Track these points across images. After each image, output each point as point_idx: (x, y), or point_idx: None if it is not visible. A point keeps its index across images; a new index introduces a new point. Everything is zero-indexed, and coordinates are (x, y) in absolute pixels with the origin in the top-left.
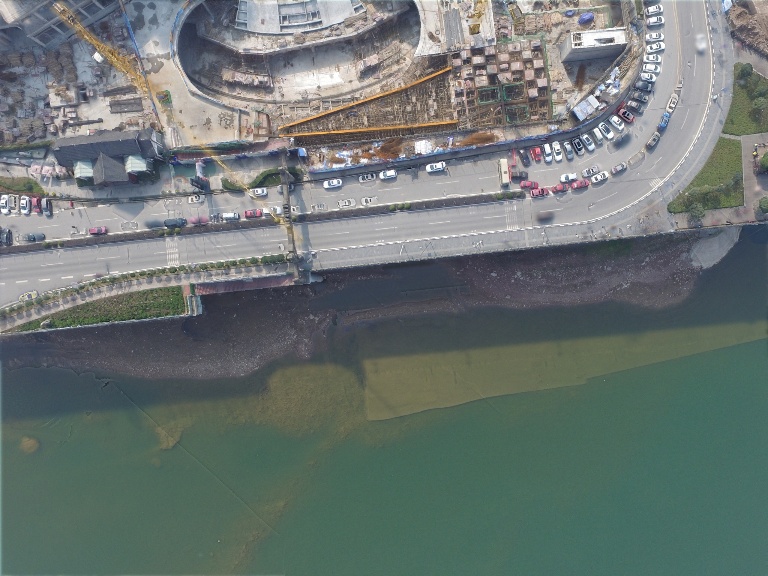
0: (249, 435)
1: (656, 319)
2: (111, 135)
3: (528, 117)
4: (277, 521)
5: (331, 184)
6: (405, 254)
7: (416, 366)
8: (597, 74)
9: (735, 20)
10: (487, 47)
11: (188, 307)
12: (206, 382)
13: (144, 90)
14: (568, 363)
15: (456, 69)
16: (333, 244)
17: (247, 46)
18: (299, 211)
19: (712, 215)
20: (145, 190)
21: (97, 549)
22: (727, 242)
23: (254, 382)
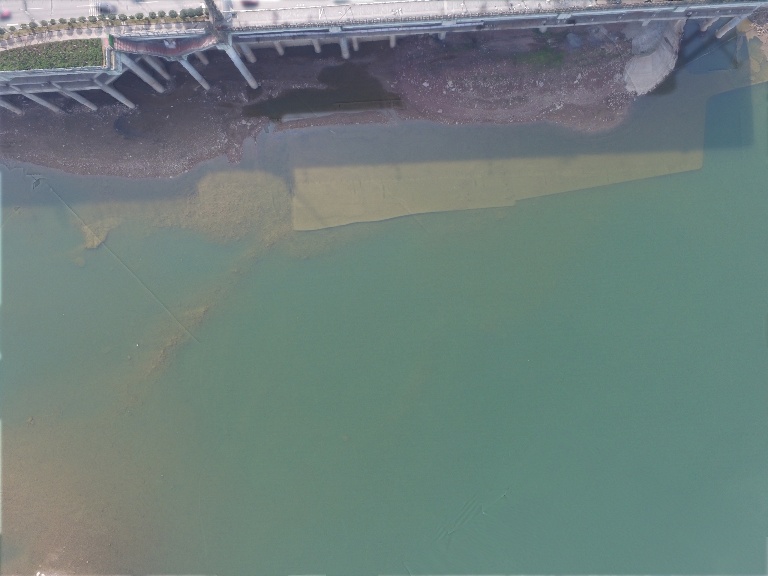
0: (175, 239)
1: (588, 144)
2: None
3: None
4: (197, 327)
5: None
6: (324, 18)
7: (345, 178)
8: None
9: None
10: None
11: (106, 60)
12: (135, 183)
13: None
14: (498, 183)
15: None
16: (254, 6)
17: None
18: None
19: None
20: None
21: (17, 351)
22: (661, 66)
23: (183, 186)
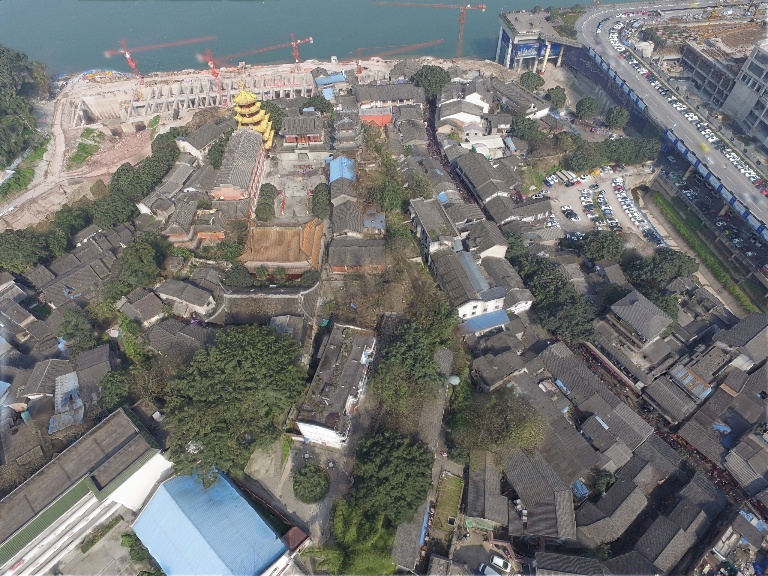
0: None
1: None
2: None
3: None
4: None
5: None
6: (685, 1)
7: None
8: None
9: None
10: None
11: None
12: None
13: None
14: None
15: None
16: None
17: None
18: (736, 6)
19: None
20: None
21: None
22: None
23: None
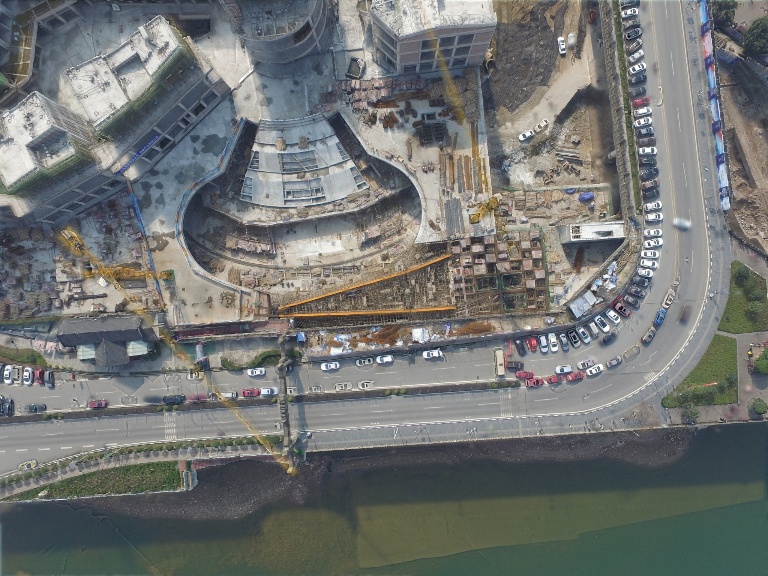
0: None
1: (650, 477)
2: (114, 323)
3: (525, 306)
4: None
5: (328, 368)
6: (399, 438)
7: (409, 515)
8: (595, 257)
9: (735, 193)
10: (487, 236)
11: (184, 482)
12: (200, 523)
13: (148, 267)
14: (560, 518)
15: (455, 255)
16: (329, 425)
17: (251, 217)
18: (296, 392)
19: (706, 411)
20: (146, 366)
21: None
22: None
23: (248, 525)
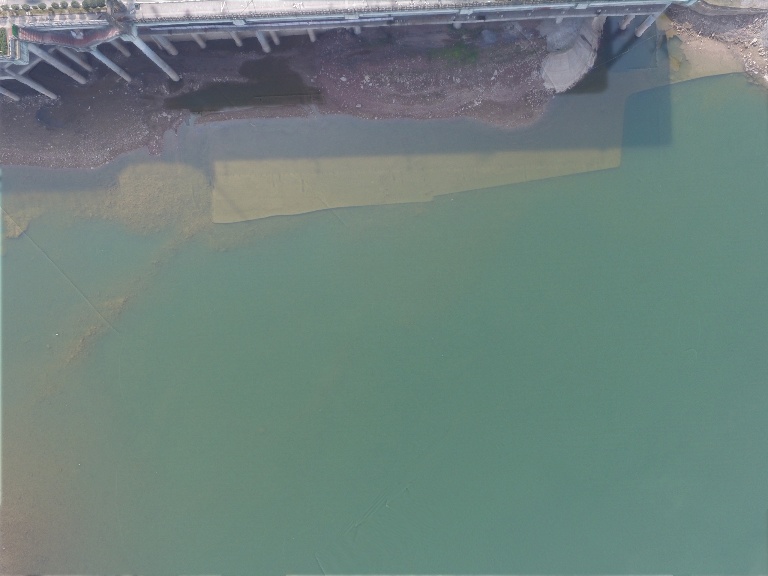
0: (95, 230)
1: (507, 141)
2: None
3: None
4: (116, 318)
5: None
6: (226, 11)
7: (265, 171)
8: None
9: None
10: None
11: None
12: (57, 173)
13: None
14: (416, 179)
15: None
16: None
17: None
18: None
19: None
20: None
21: None
22: (579, 63)
23: (104, 177)
